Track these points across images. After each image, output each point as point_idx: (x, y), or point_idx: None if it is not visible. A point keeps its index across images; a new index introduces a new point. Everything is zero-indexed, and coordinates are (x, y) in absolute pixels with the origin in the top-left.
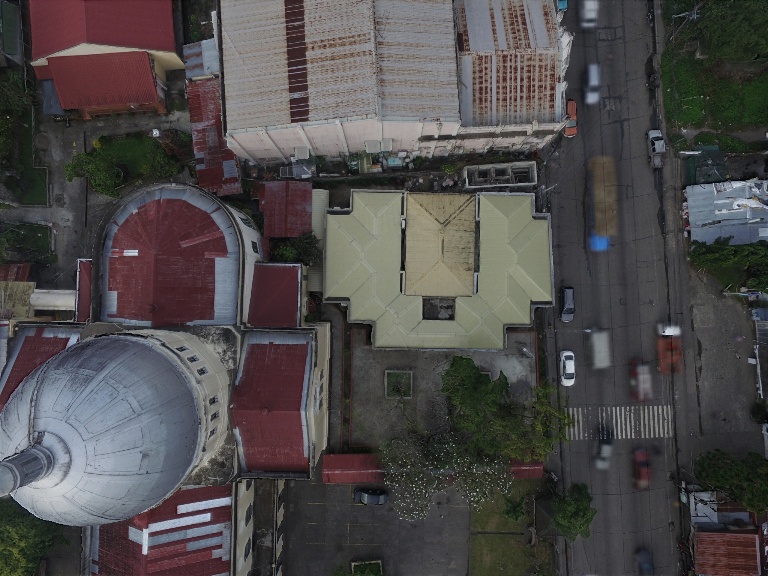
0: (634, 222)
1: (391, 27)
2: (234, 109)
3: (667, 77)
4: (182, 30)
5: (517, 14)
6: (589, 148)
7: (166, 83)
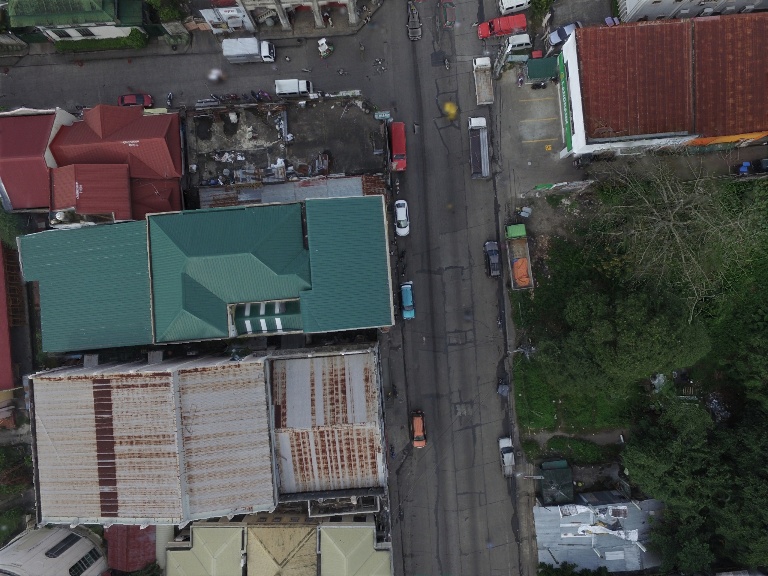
0: (487, 530)
1: (199, 420)
2: (48, 495)
3: (518, 383)
4: (30, 343)
5: (337, 380)
6: (441, 455)
7: (14, 400)
